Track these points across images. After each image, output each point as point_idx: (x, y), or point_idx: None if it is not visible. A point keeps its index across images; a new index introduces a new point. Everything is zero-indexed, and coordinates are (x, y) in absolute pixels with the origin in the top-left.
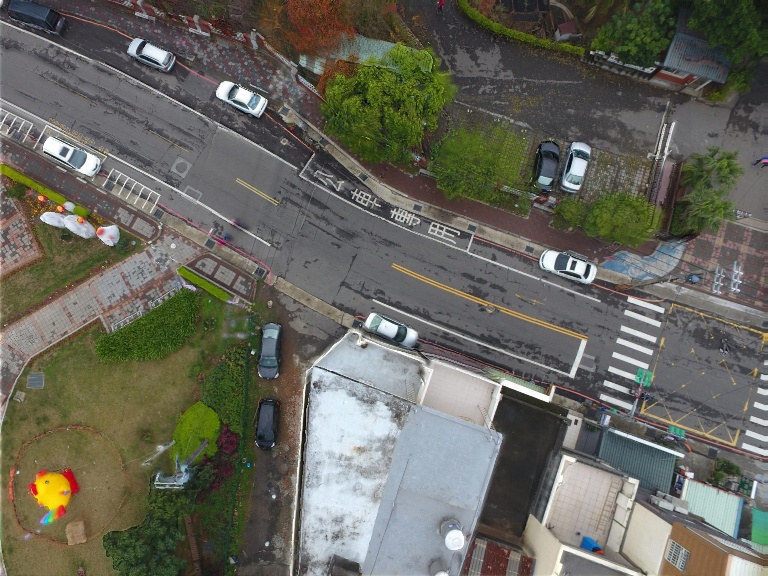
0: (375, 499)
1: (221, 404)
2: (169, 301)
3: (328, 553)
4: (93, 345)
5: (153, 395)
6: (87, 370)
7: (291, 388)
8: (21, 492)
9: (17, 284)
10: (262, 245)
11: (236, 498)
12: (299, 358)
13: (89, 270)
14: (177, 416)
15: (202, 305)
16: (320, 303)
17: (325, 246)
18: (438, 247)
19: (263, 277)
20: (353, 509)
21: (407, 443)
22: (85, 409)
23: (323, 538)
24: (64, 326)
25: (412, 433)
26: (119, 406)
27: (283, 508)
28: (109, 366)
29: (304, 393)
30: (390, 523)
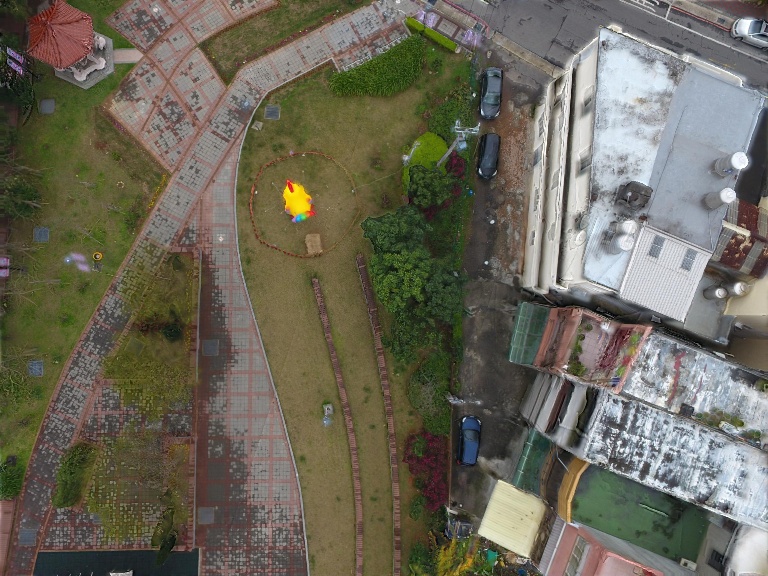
0: (655, 142)
1: (451, 132)
2: (399, 44)
3: (615, 185)
4: (326, 83)
5: (383, 128)
6: (323, 102)
7: (507, 130)
8: (258, 210)
9: (255, 27)
10: (481, 3)
11: (459, 220)
12: (514, 104)
13: (321, 18)
14: (404, 148)
15: (427, 52)
16: (534, 56)
17: (538, 7)
18: (640, 14)
19: (482, 31)
20: (636, 149)
21: (682, 98)
22: (321, 137)
23: (610, 172)
24: (298, 66)
25: (686, 89)
26: (352, 135)
27: (500, 233)
28: (344, 99)
29: (572, 74)
30: (668, 163)
